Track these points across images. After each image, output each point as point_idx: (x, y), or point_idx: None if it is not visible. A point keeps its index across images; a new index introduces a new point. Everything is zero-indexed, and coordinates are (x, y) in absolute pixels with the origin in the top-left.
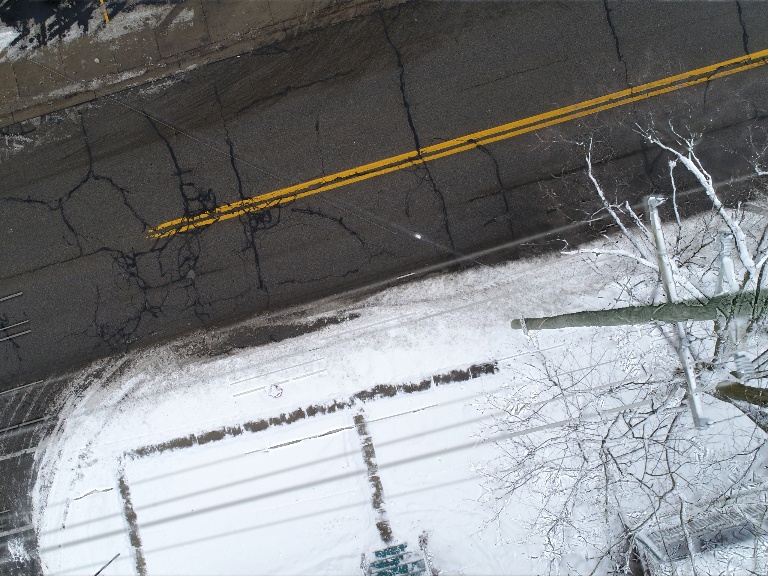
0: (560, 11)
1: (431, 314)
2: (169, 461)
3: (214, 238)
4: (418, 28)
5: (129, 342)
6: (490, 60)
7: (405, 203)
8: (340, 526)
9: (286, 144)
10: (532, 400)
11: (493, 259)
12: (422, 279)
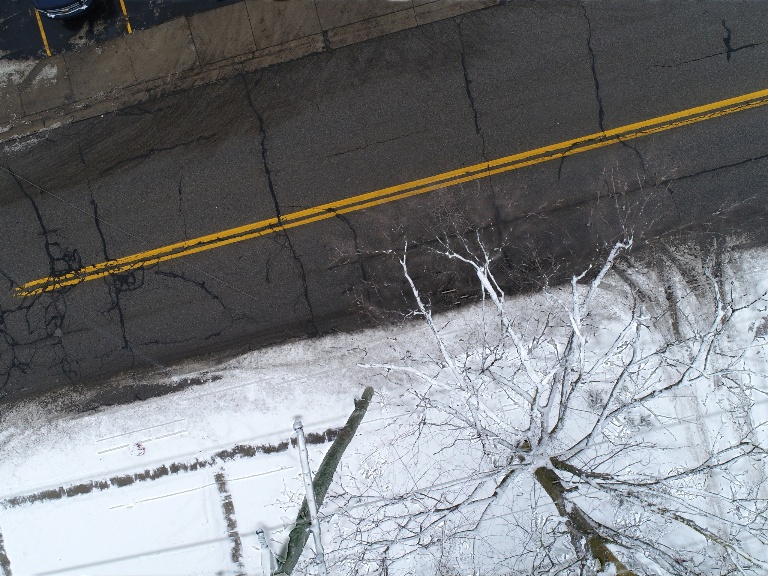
0: (420, 81)
1: (288, 379)
2: (38, 512)
3: (80, 298)
4: (280, 93)
5: None
6: (350, 129)
7: (266, 269)
8: None
9: (149, 207)
10: (382, 465)
11: (350, 326)
12: (282, 344)
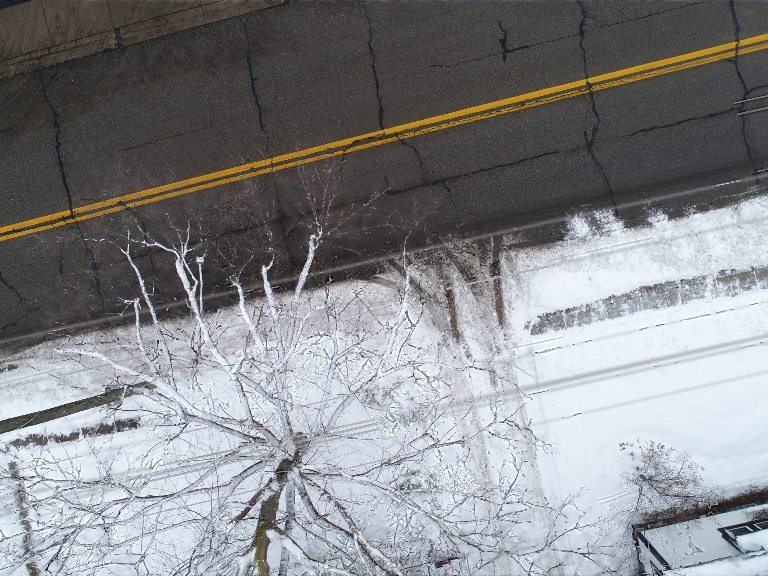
0: (208, 78)
1: (78, 370)
2: None
3: None
4: (74, 88)
5: None
6: (140, 124)
7: (59, 261)
8: None
9: None
10: (165, 456)
11: (140, 319)
12: (75, 335)
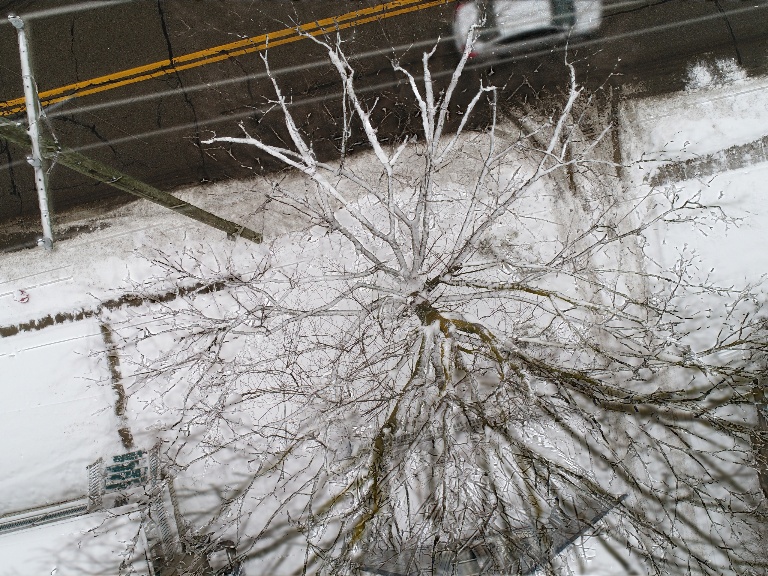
0: None
1: (177, 225)
2: None
3: None
4: None
5: None
6: None
7: (157, 113)
8: (80, 430)
9: (41, 47)
10: None
11: (242, 173)
12: (172, 191)
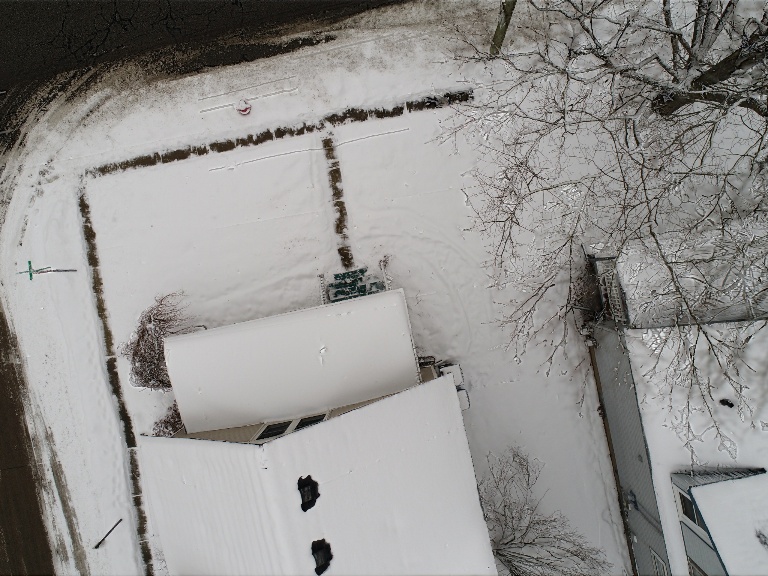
0: None
1: (409, 36)
2: (131, 176)
3: None
4: None
5: (96, 55)
6: None
7: None
8: (301, 246)
9: None
10: None
11: None
12: (403, 2)
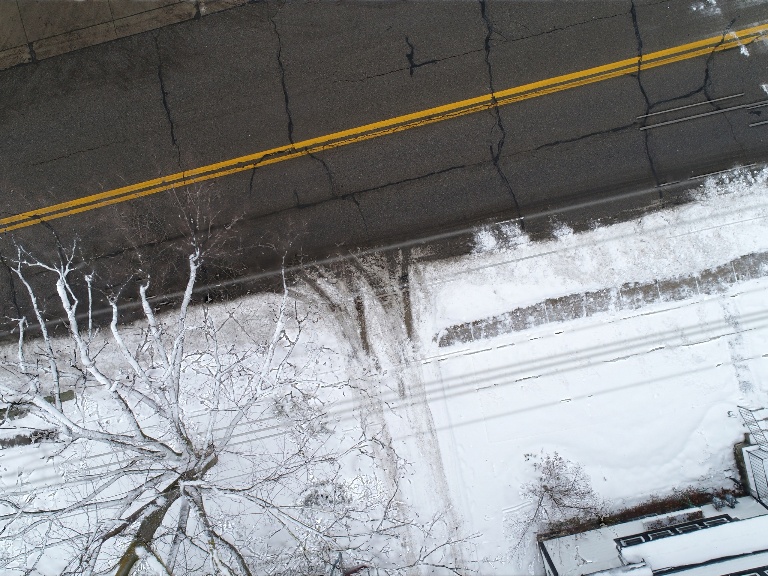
0: (120, 92)
1: None
2: None
3: None
4: None
5: None
6: (54, 138)
7: None
8: None
9: None
10: None
11: (57, 331)
12: None
